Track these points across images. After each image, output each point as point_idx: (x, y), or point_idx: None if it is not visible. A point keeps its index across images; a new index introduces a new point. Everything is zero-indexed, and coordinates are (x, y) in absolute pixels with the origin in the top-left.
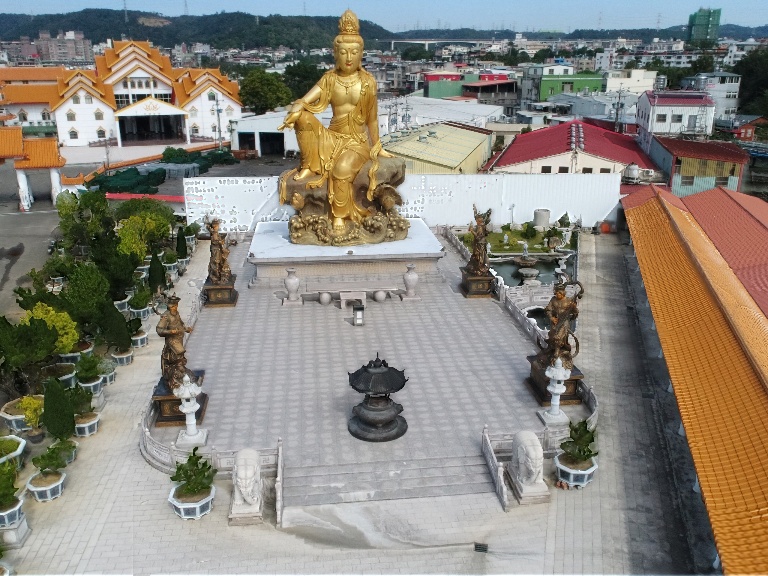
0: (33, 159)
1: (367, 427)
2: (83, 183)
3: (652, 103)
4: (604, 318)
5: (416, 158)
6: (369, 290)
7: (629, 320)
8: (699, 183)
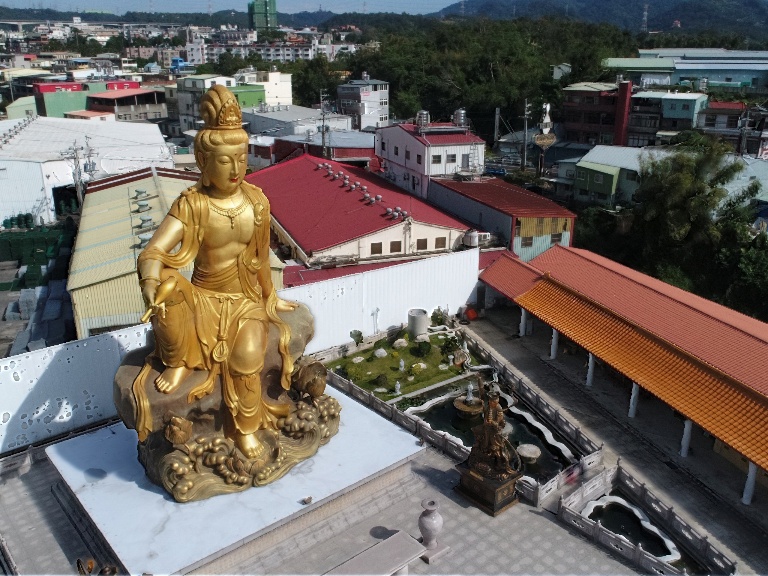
0: None
1: None
2: None
3: (426, 143)
4: (677, 499)
5: None
6: (391, 574)
7: (702, 492)
8: (537, 243)
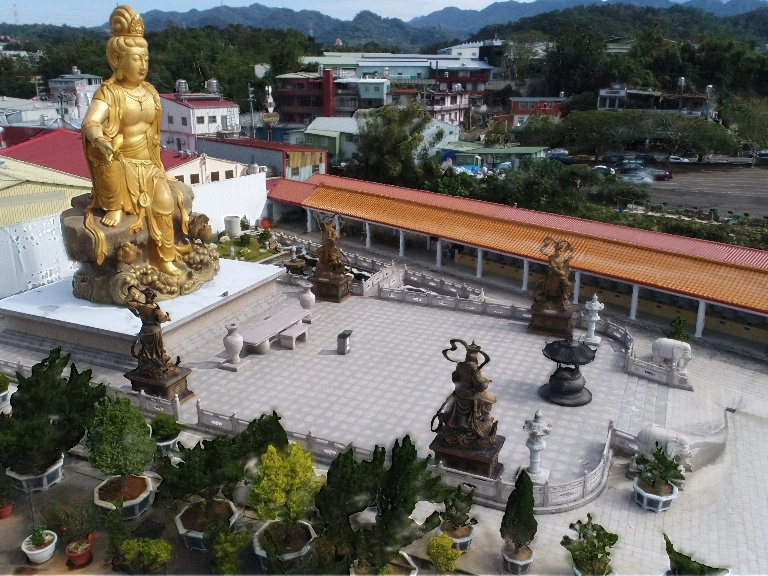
0: None
1: (575, 395)
2: None
3: (190, 106)
4: None
5: (69, 186)
6: None
7: (455, 278)
8: (303, 172)
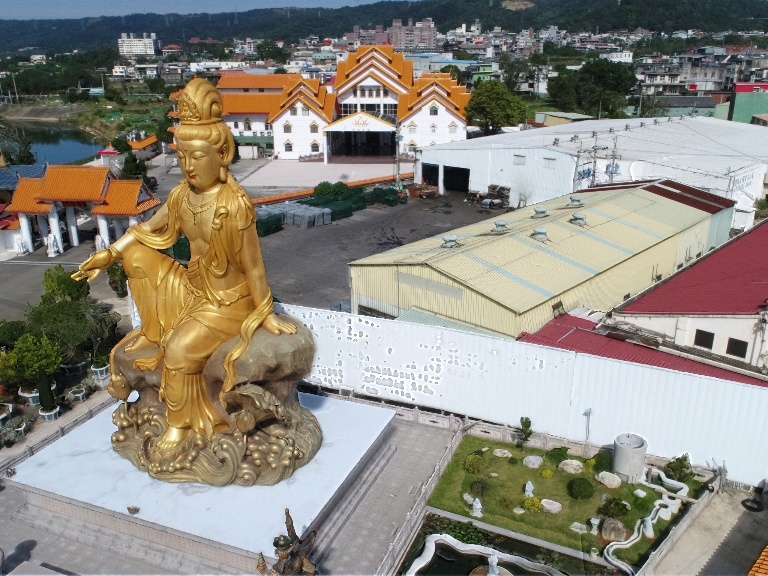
0: (112, 204)
1: None
2: None
3: None
4: None
5: (466, 285)
6: None
7: None
8: None
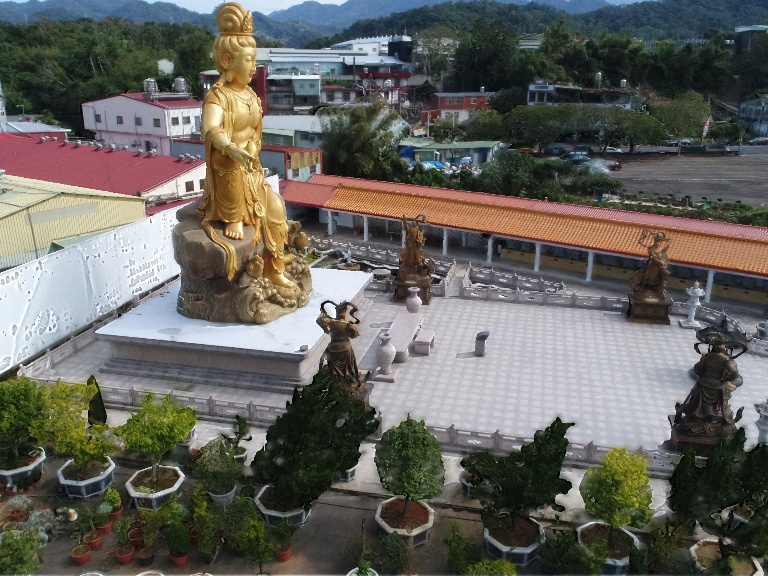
0: None
1: None
2: None
3: (165, 107)
4: None
5: (102, 196)
6: None
7: None
8: (302, 173)
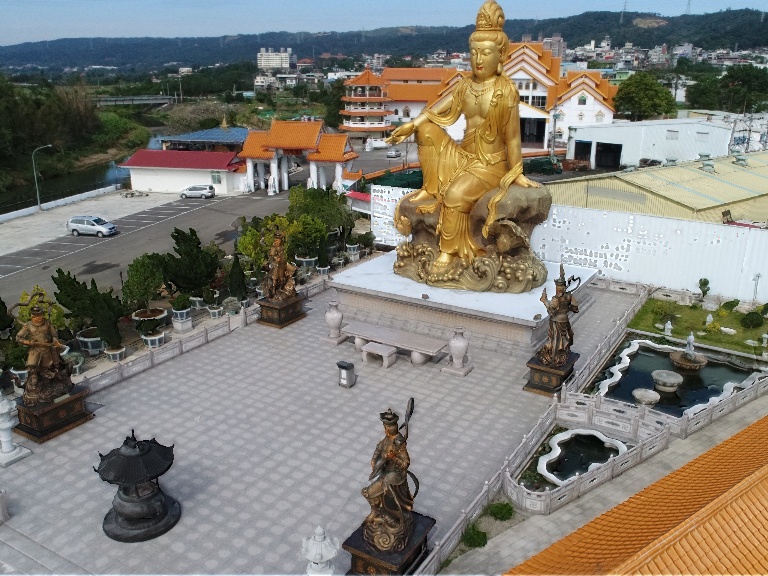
0: (323, 152)
1: None
2: (359, 179)
3: None
4: None
5: (650, 191)
6: (402, 347)
7: None
8: None
